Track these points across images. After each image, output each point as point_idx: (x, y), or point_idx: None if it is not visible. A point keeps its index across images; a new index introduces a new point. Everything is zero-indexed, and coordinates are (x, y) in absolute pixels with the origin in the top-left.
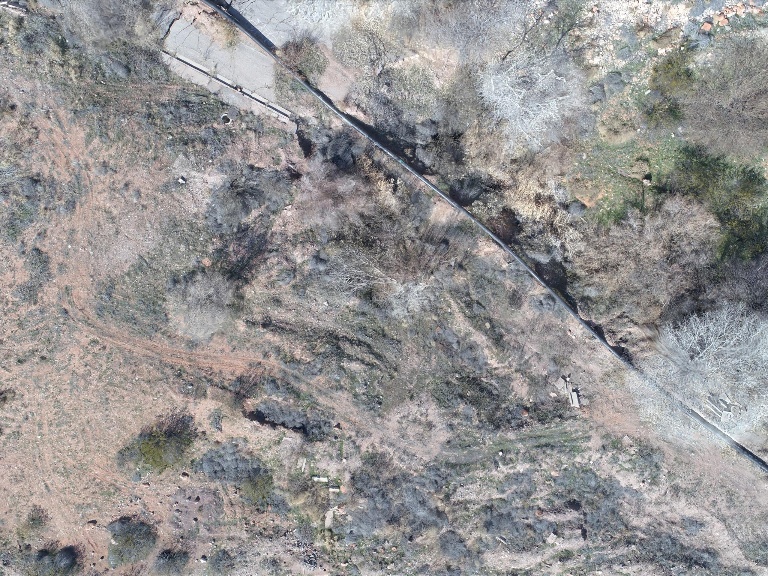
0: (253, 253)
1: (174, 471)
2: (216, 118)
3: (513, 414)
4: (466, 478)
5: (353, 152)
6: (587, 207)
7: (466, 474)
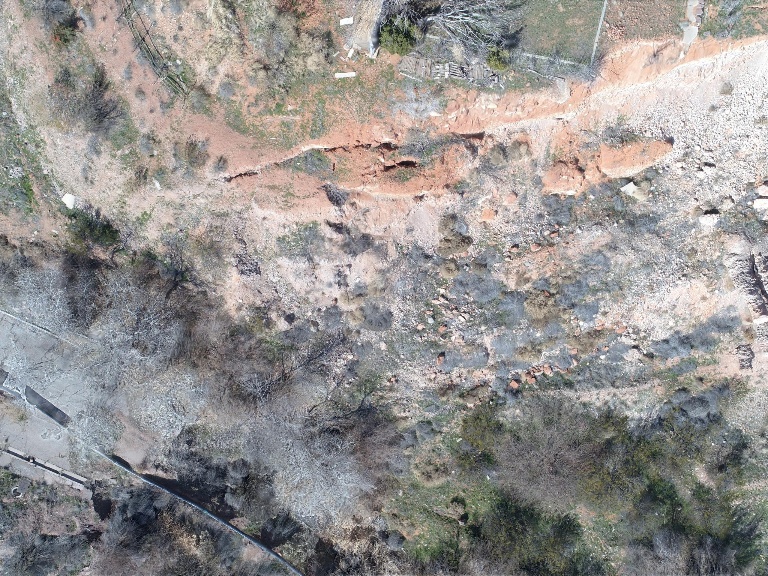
0: None
1: None
2: (6, 492)
3: None
4: None
5: (156, 506)
6: (406, 539)
7: None
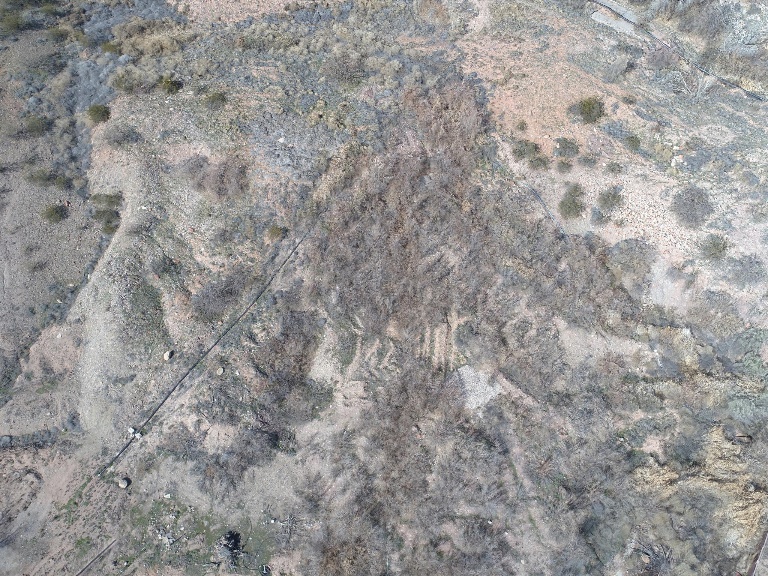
0: None
1: (590, 126)
2: None
3: None
4: None
5: None
6: None
7: (751, 149)
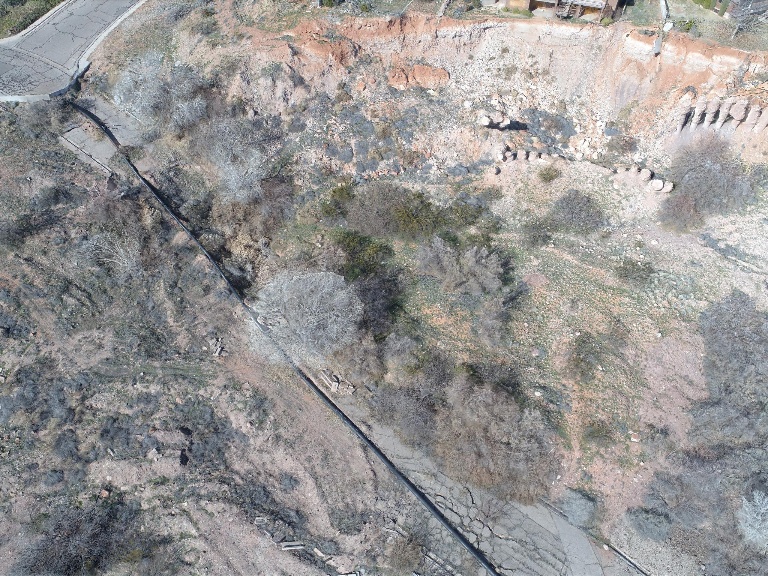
0: (46, 224)
1: None
2: None
3: None
4: (106, 388)
5: (139, 196)
6: (280, 257)
7: (107, 384)
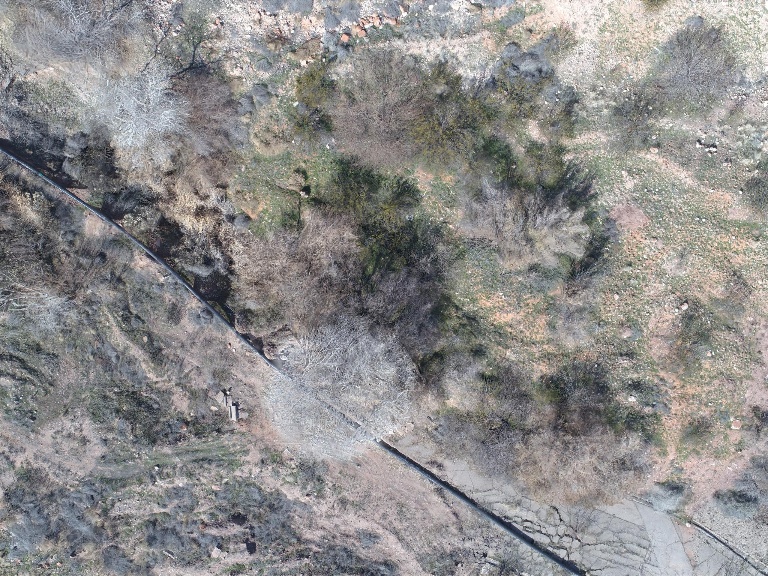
0: None
1: None
2: None
3: (172, 428)
4: (124, 493)
5: None
6: (252, 219)
7: (123, 489)
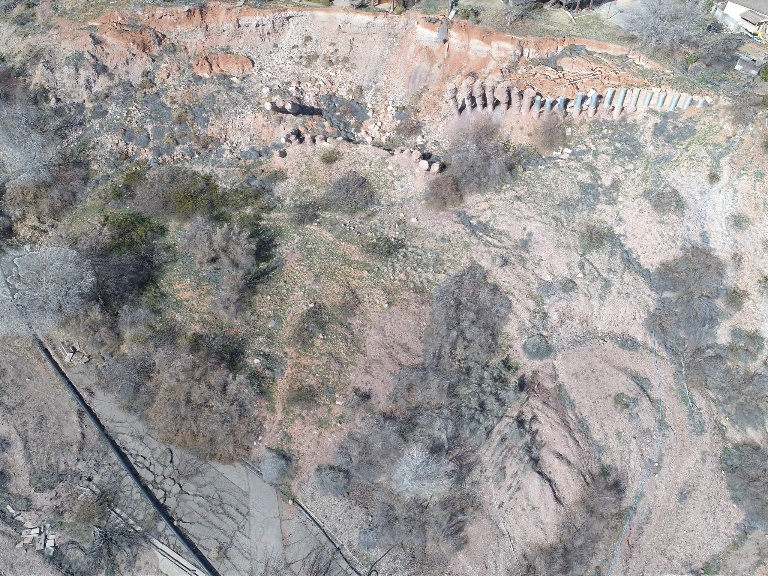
0: None
1: None
2: None
3: None
4: None
5: None
6: (63, 238)
7: None
